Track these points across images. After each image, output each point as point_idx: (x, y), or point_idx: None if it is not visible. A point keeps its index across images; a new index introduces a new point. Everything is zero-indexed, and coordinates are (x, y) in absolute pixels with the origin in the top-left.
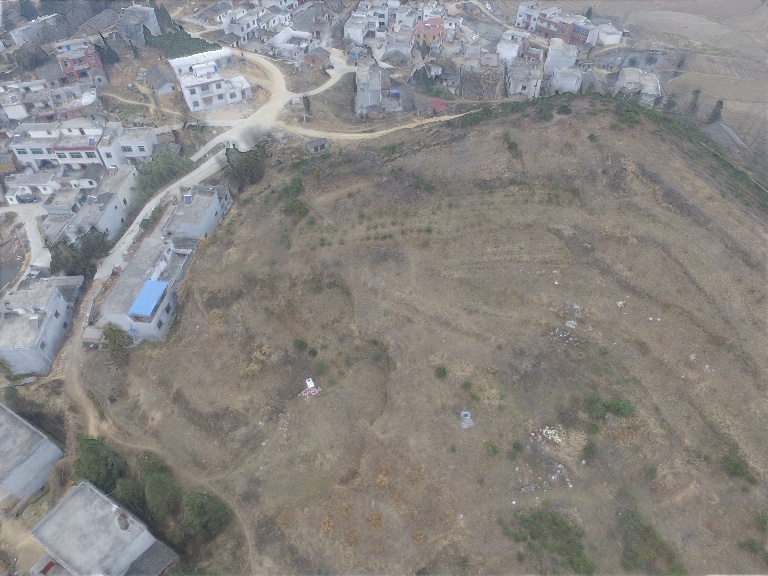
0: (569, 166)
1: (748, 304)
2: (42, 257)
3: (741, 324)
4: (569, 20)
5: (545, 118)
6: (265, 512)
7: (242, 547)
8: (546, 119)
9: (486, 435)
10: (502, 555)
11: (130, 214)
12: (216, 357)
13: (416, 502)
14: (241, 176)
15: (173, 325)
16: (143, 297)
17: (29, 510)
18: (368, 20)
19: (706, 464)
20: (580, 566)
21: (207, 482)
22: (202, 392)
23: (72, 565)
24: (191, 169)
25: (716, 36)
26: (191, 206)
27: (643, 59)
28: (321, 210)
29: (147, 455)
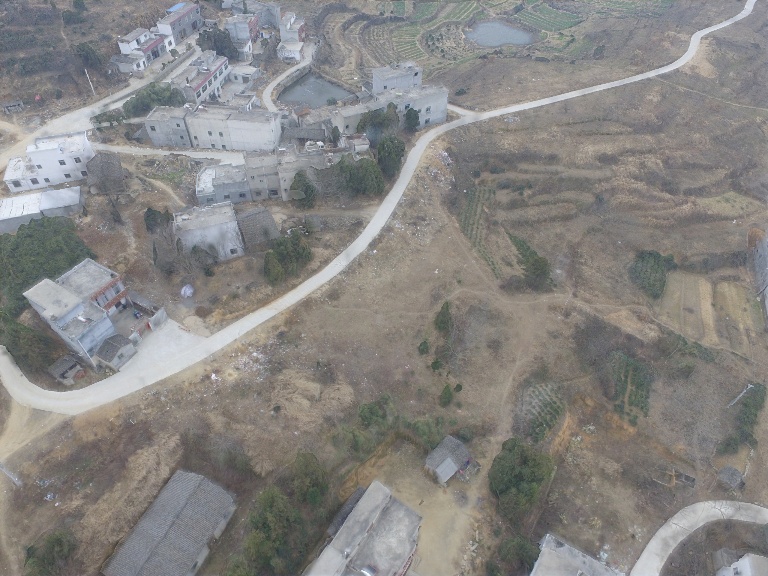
0: None
1: None
2: (251, 71)
3: None
4: None
5: None
6: None
7: None
8: None
9: None
10: None
11: None
12: None
13: None
14: None
15: None
16: None
17: None
18: None
19: None
20: None
21: None
22: None
23: None
24: None
25: None
26: (138, 36)
27: None
28: (66, 3)
29: None
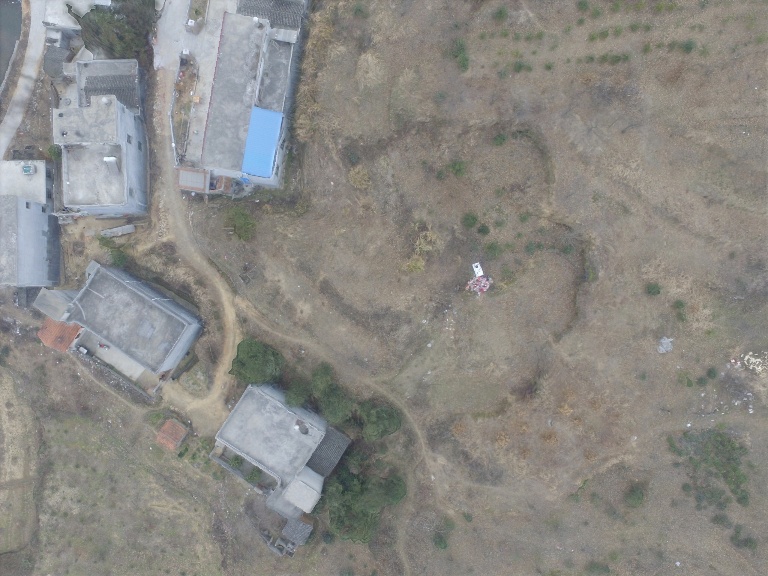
0: None
1: None
2: (53, 4)
3: None
4: None
5: None
6: (437, 417)
7: (415, 444)
8: None
9: (682, 361)
10: None
11: None
12: (368, 241)
13: (594, 425)
14: None
15: (289, 162)
16: (255, 140)
17: (186, 380)
18: None
19: None
20: (732, 480)
21: (373, 382)
22: (357, 287)
23: (266, 464)
24: None
25: None
26: None
27: None
28: None
29: (303, 349)
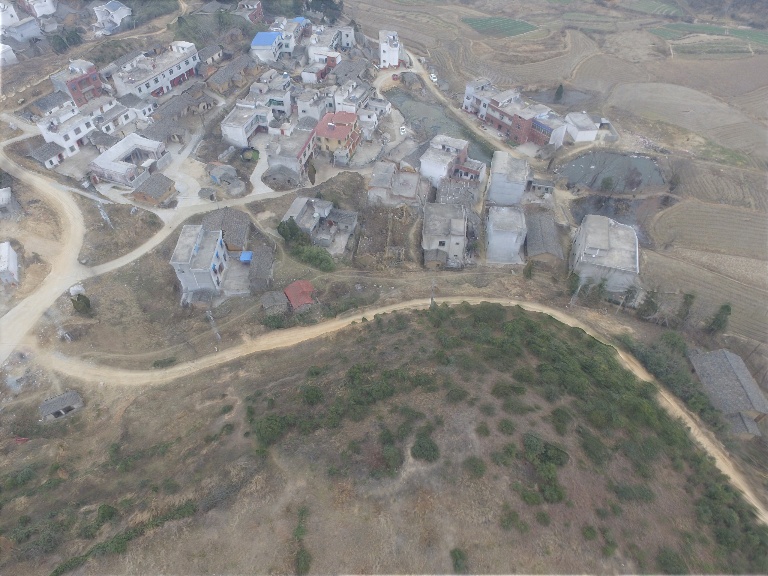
0: None
1: None
2: None
3: None
4: (526, 113)
5: (388, 465)
6: None
7: None
8: (390, 467)
9: None
10: None
11: None
12: None
13: None
14: None
15: None
16: None
17: None
18: (256, 113)
19: None
20: None
21: None
22: None
23: None
24: None
25: (724, 127)
26: None
27: (622, 180)
28: None
29: None
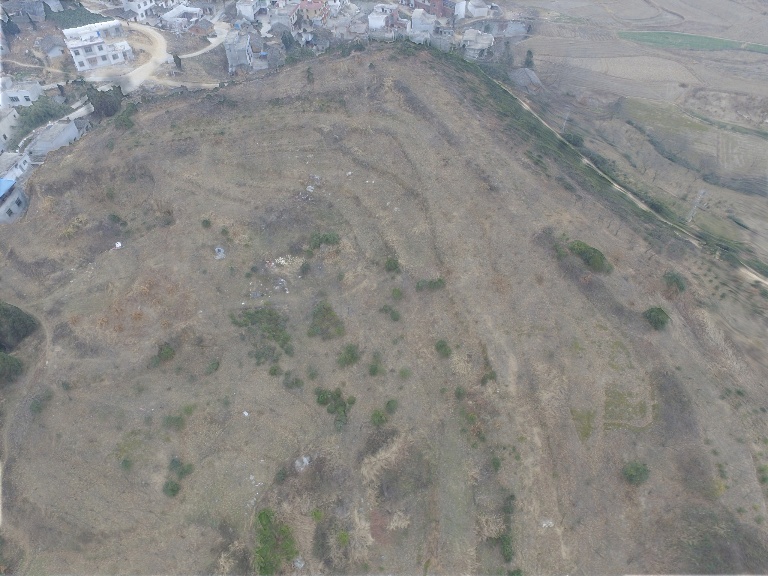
0: (345, 86)
1: (437, 168)
2: None
3: (427, 180)
4: None
5: (344, 55)
6: (62, 320)
7: (42, 343)
8: (345, 56)
9: (232, 263)
10: (228, 336)
11: (9, 147)
12: (44, 226)
13: (169, 304)
14: (98, 110)
15: (24, 216)
16: None
17: None
18: None
19: (376, 267)
20: (280, 338)
21: (24, 307)
22: (29, 249)
23: None
24: (67, 113)
25: (575, 8)
26: (49, 131)
27: (496, 26)
28: (143, 124)
29: None
